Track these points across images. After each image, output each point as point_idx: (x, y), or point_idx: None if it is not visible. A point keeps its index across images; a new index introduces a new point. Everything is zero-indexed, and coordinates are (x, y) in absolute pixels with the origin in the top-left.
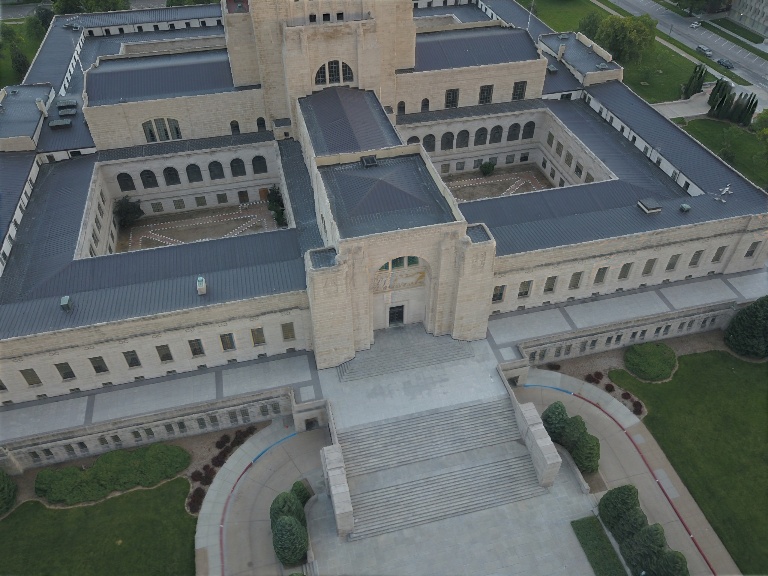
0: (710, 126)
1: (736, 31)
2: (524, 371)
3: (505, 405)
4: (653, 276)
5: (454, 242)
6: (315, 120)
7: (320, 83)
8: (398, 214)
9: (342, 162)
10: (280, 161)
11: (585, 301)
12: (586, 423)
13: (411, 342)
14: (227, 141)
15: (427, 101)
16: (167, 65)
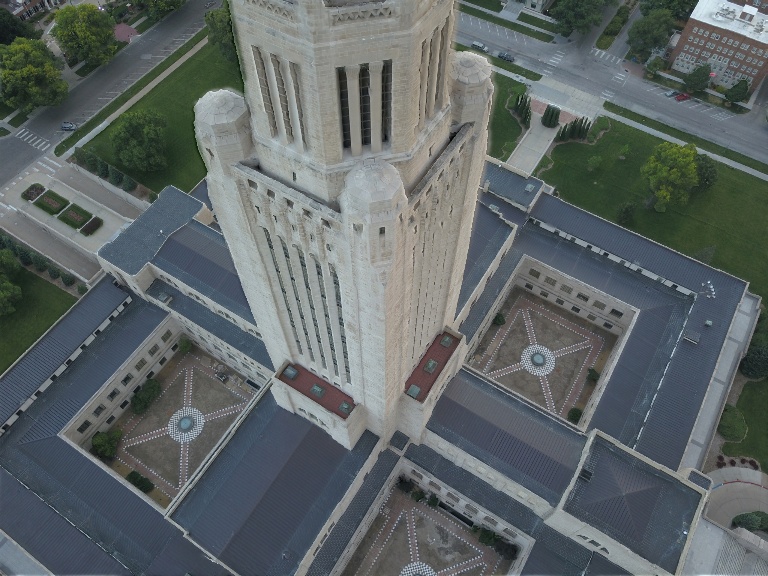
0: (566, 153)
1: (473, 1)
2: None
3: (729, 540)
4: None
5: None
6: (472, 445)
7: None
8: (657, 511)
9: None
10: (436, 478)
11: None
12: (745, 499)
13: None
14: (367, 491)
15: None
16: (268, 479)
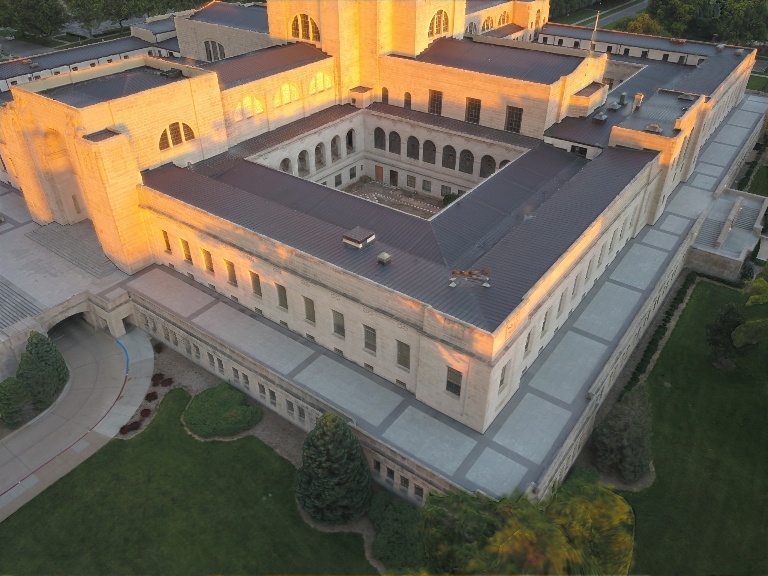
0: None
1: None
2: (107, 317)
3: None
4: (318, 329)
5: (74, 130)
6: None
7: (296, 36)
8: (95, 101)
9: (161, 68)
10: None
11: (244, 311)
12: (86, 399)
13: (85, 238)
14: None
15: (410, 96)
16: None
